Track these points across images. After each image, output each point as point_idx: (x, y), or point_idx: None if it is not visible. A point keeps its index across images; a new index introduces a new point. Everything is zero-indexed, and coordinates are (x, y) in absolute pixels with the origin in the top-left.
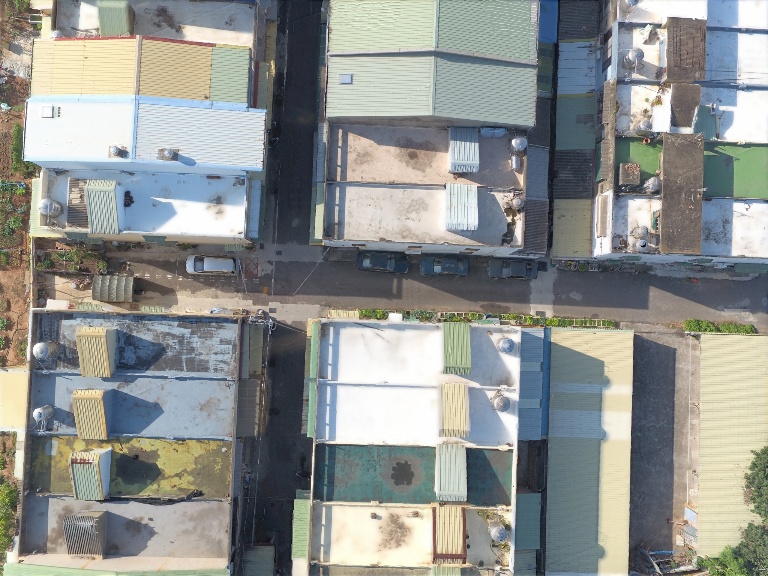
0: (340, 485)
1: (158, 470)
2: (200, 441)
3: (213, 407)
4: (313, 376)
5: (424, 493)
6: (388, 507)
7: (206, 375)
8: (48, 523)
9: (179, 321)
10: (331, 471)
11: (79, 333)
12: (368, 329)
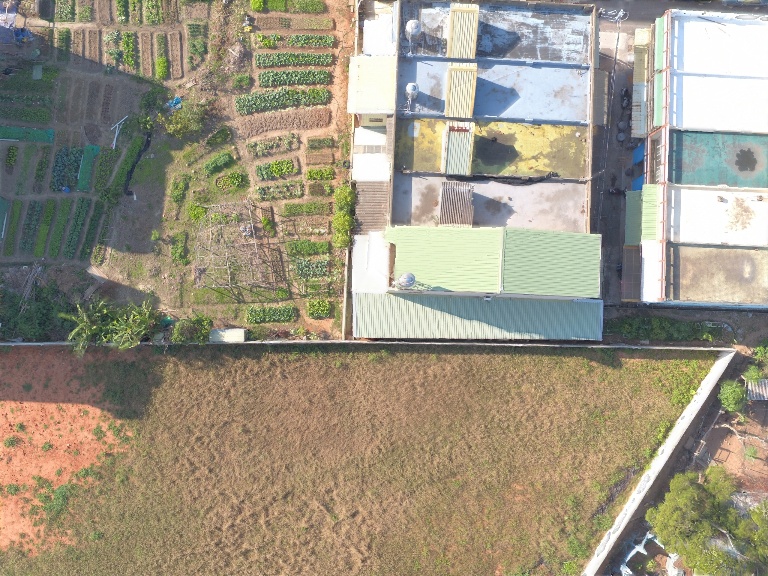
0: (688, 170)
1: (515, 152)
2: (555, 126)
3: (566, 94)
4: (659, 67)
5: (767, 179)
6: (733, 191)
7: (561, 62)
8: (412, 201)
9: (533, 12)
10: (679, 157)
11: (454, 8)
12: (711, 23)
